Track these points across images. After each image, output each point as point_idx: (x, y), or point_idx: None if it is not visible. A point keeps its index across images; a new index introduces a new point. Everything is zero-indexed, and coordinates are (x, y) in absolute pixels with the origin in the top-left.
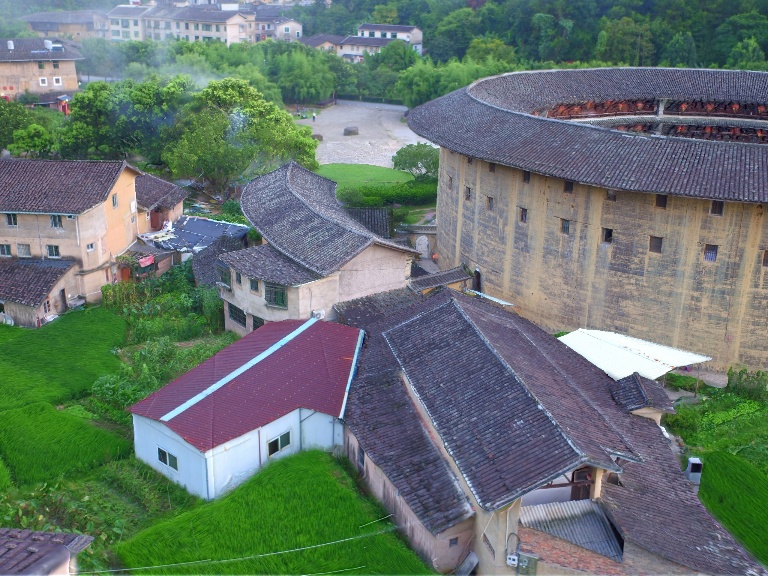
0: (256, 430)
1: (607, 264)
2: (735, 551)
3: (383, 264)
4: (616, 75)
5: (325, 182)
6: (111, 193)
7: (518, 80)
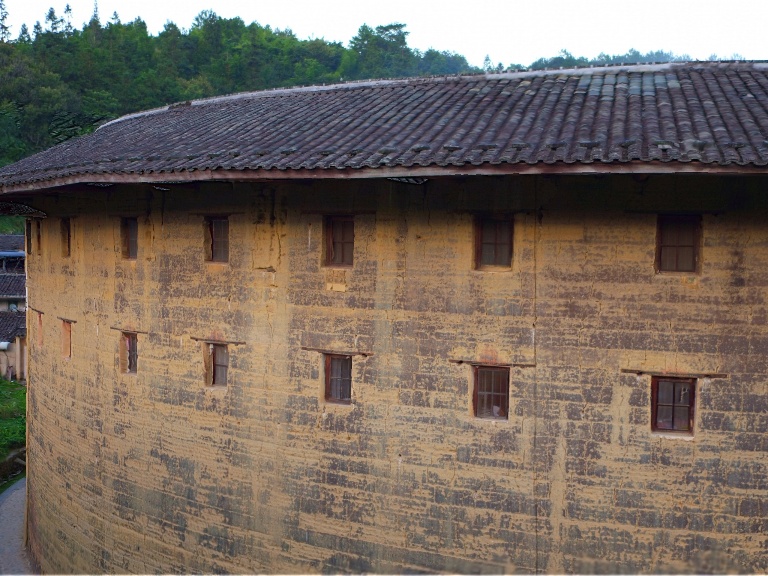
0: None
1: None
2: None
3: None
4: None
5: None
6: None
7: None
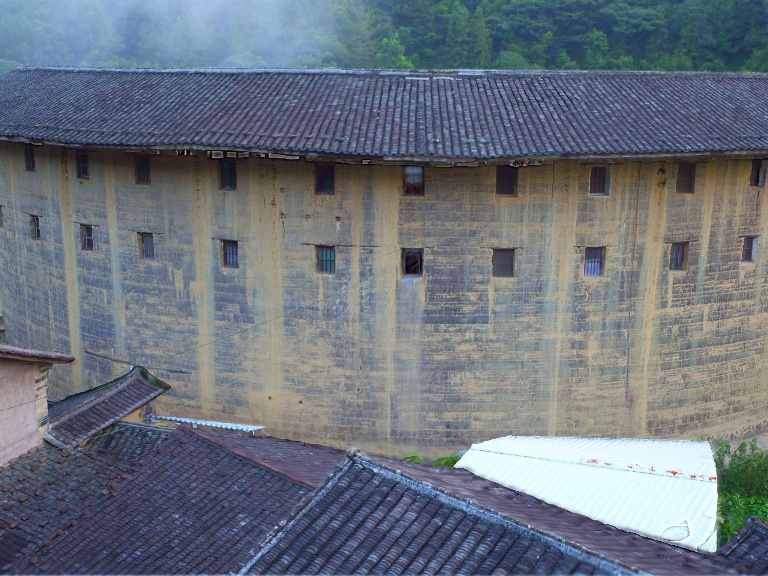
0: None
1: (418, 314)
2: None
3: None
4: None
5: None
6: None
7: None
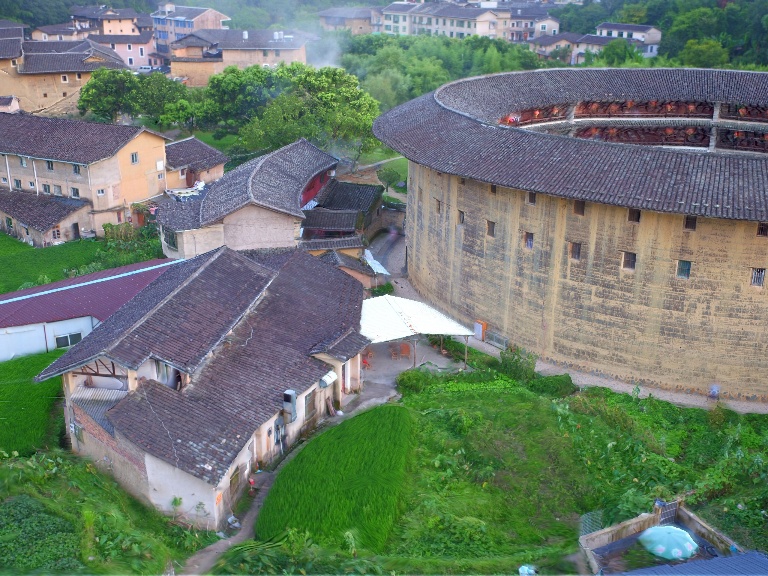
0: (41, 324)
1: (461, 244)
2: (222, 453)
3: (270, 223)
4: (676, 76)
5: (325, 158)
6: (130, 151)
7: (552, 76)
